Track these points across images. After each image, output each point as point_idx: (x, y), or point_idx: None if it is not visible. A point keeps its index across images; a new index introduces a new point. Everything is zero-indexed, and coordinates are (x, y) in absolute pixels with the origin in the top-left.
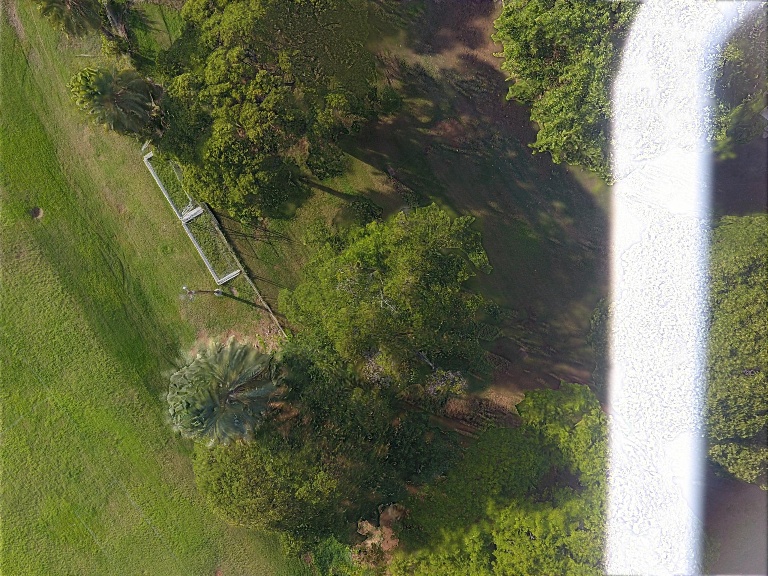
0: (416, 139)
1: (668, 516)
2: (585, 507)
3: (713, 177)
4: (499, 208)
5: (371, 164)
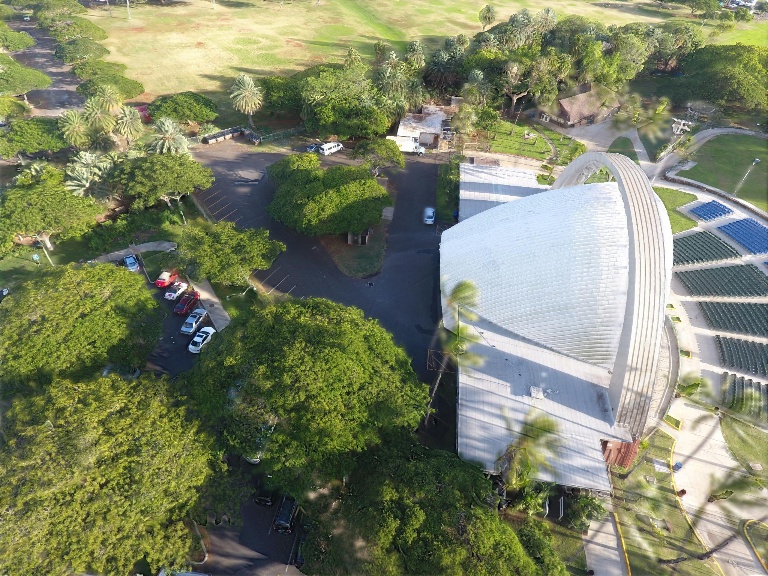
0: None
1: (736, 57)
2: (760, 58)
3: None
4: None
5: None
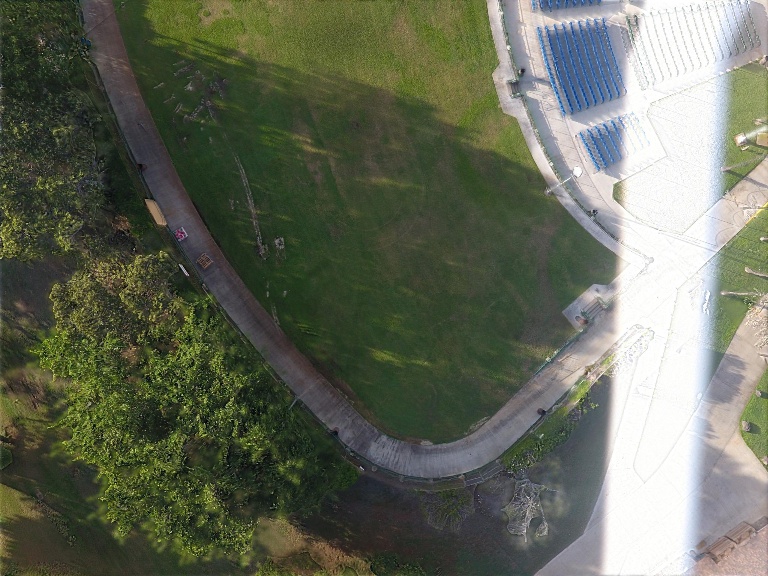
0: (63, 462)
1: None
2: None
3: (341, 500)
4: (148, 527)
5: (19, 490)
